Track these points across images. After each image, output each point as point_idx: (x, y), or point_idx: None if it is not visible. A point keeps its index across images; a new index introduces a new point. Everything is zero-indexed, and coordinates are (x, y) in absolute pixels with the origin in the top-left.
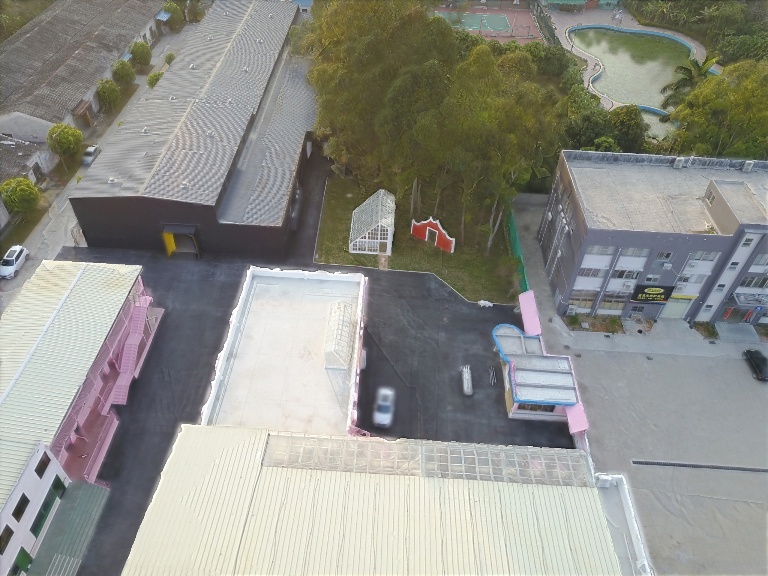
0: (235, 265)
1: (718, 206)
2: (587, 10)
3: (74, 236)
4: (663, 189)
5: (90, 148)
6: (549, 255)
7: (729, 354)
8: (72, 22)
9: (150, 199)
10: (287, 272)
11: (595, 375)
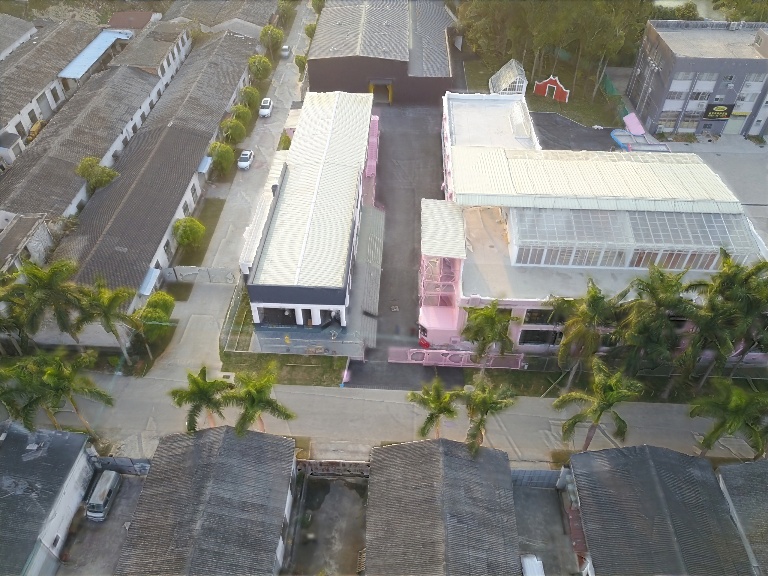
0: (417, 109)
1: (765, 44)
2: None
3: (302, 92)
4: (724, 41)
5: (284, 47)
6: (639, 99)
7: None
8: None
9: (365, 58)
10: (471, 95)
11: None
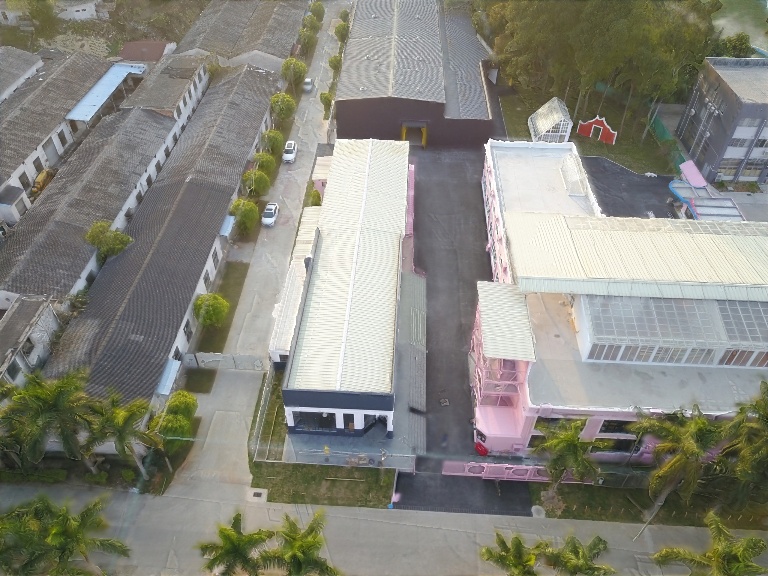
0: (453, 153)
1: None
2: None
3: (329, 134)
4: None
5: (307, 80)
6: (693, 142)
7: None
8: None
9: (398, 99)
10: (516, 143)
11: (746, 218)
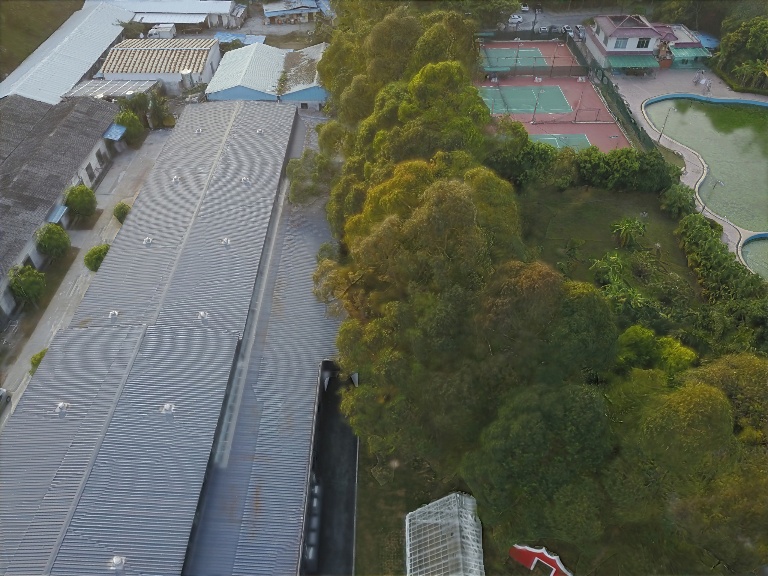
0: None
1: None
2: (659, 72)
3: None
4: None
5: None
6: None
7: None
8: None
9: None
10: None
11: None
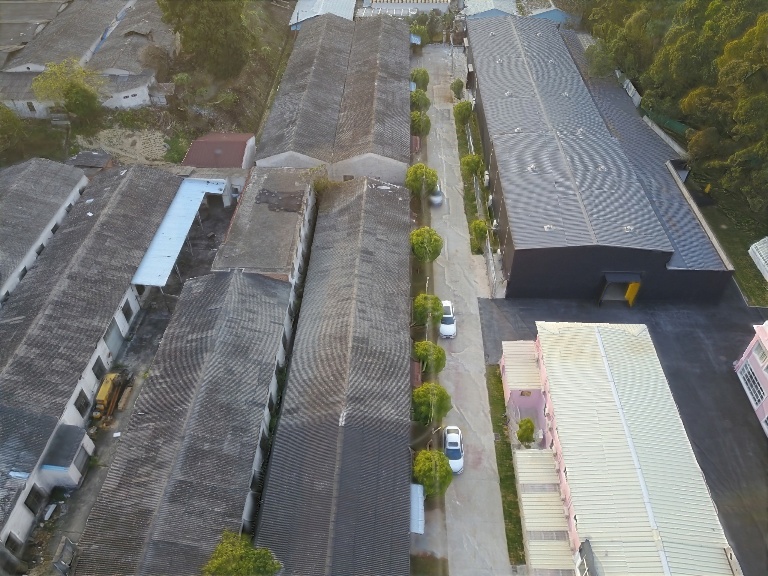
0: (672, 313)
1: None
2: None
3: (495, 287)
4: None
5: None
6: None
7: None
8: (338, 51)
9: (608, 248)
10: None
11: None
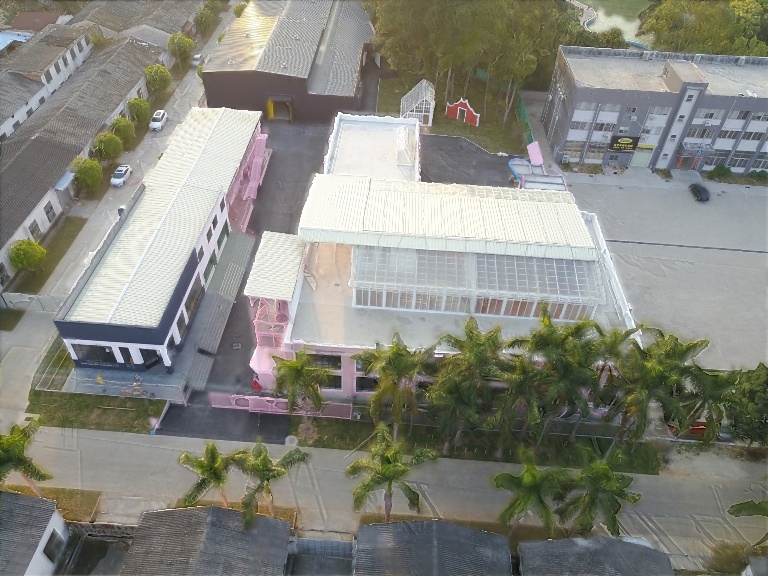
0: (318, 128)
1: (671, 76)
2: None
3: (200, 106)
4: (633, 71)
5: (196, 56)
6: (550, 126)
7: (678, 185)
8: None
9: (261, 73)
10: (364, 117)
11: (581, 196)
